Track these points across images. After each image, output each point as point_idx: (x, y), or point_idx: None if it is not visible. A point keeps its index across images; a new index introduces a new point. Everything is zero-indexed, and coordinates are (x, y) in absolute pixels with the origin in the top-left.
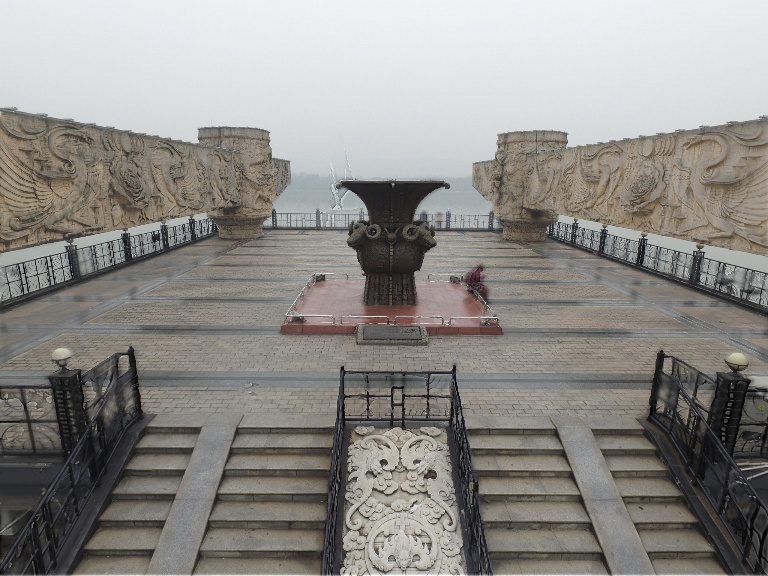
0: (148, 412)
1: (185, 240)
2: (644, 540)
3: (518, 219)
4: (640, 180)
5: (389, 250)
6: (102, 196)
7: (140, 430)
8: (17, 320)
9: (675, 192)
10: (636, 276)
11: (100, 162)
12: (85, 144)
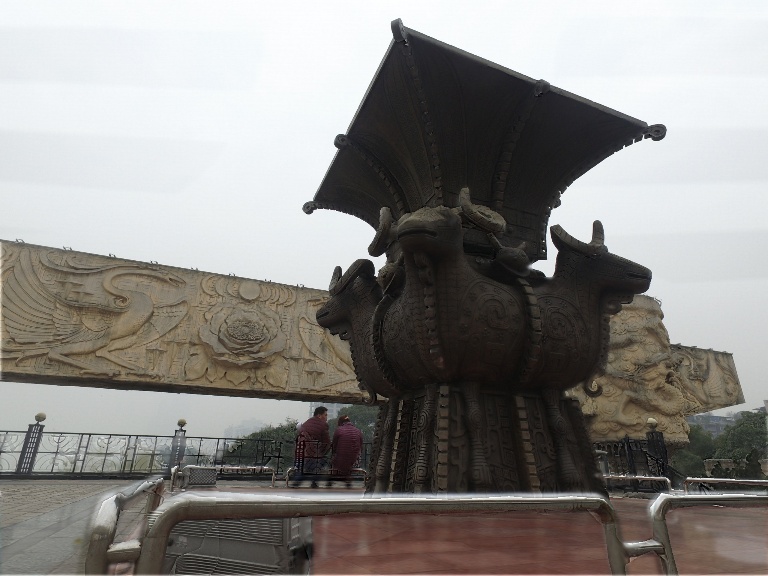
0: None
1: None
2: None
3: None
4: (242, 325)
5: None
6: None
7: None
8: None
9: (306, 345)
10: None
11: None
12: None
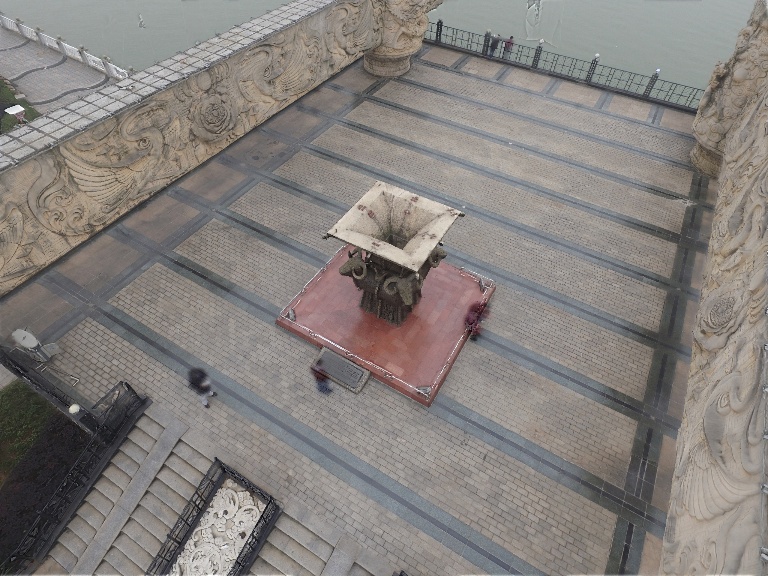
0: (151, 397)
1: None
2: None
3: (711, 148)
4: (727, 304)
5: None
6: (182, 147)
7: (138, 416)
8: (143, 227)
9: (715, 367)
10: None
11: (176, 118)
12: (158, 110)
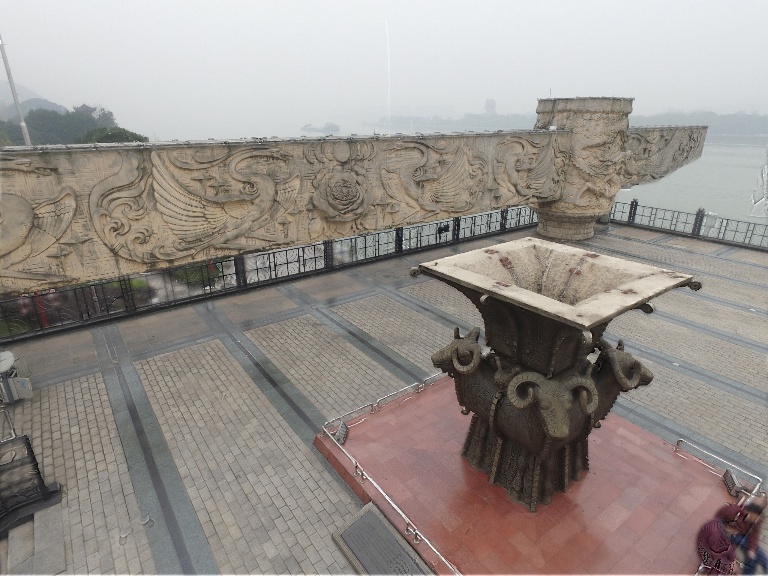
0: (65, 493)
1: (488, 231)
2: None
3: None
4: None
5: None
6: (295, 212)
7: (23, 516)
8: (231, 308)
9: None
10: None
11: (297, 177)
12: (280, 162)
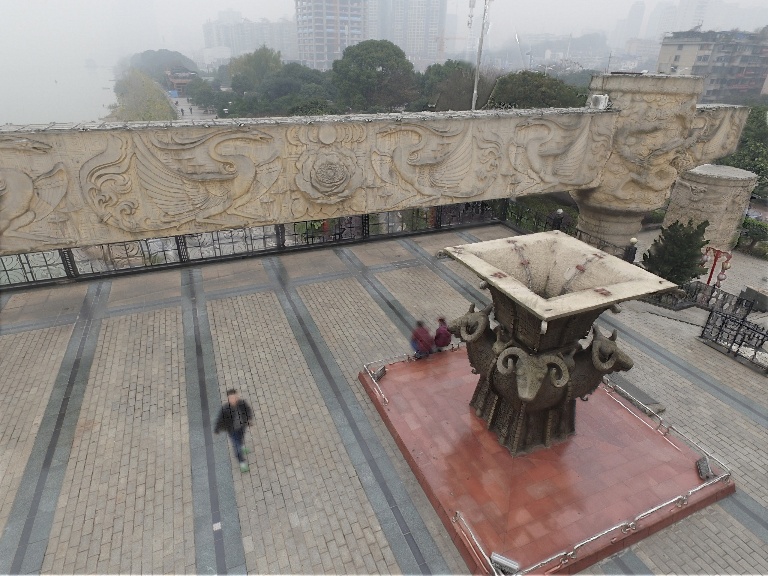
0: None
1: None
2: None
3: None
4: (327, 169)
5: None
6: None
7: None
8: None
9: (378, 175)
10: (239, 269)
11: None
12: None
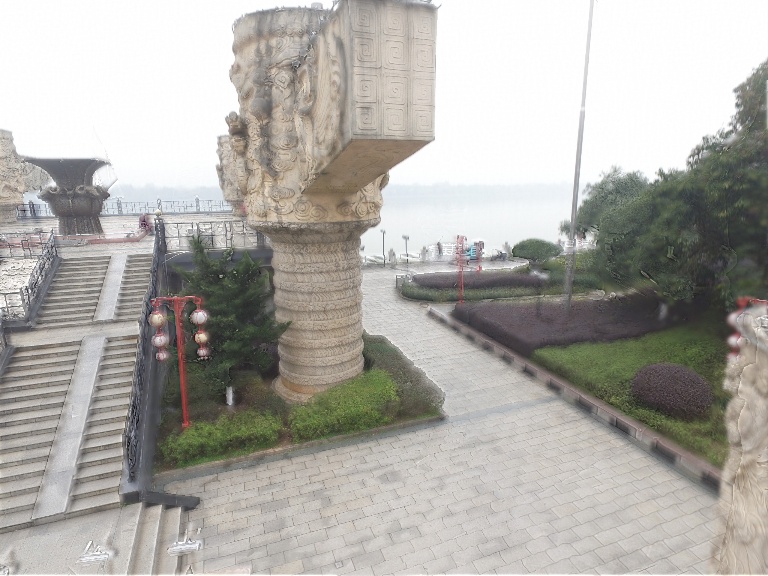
0: None
1: None
2: (124, 279)
3: (236, 198)
4: None
5: (69, 201)
6: None
7: None
8: None
9: None
10: None
11: None
12: None
